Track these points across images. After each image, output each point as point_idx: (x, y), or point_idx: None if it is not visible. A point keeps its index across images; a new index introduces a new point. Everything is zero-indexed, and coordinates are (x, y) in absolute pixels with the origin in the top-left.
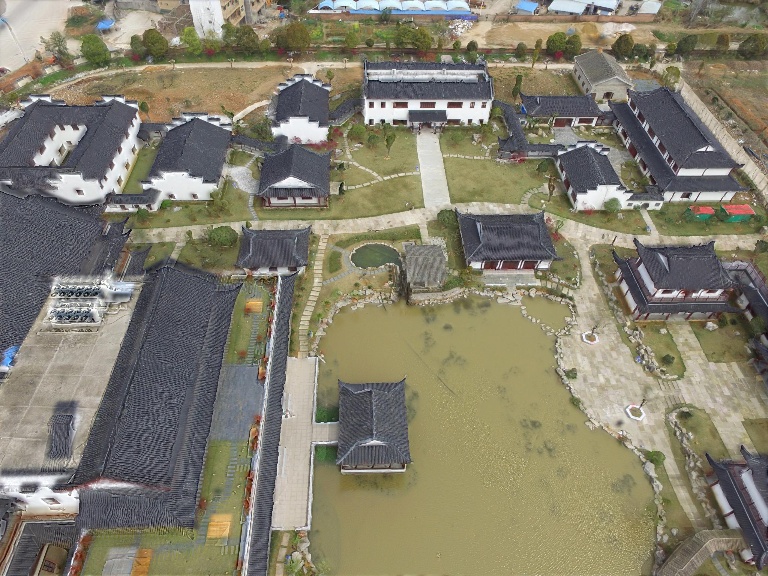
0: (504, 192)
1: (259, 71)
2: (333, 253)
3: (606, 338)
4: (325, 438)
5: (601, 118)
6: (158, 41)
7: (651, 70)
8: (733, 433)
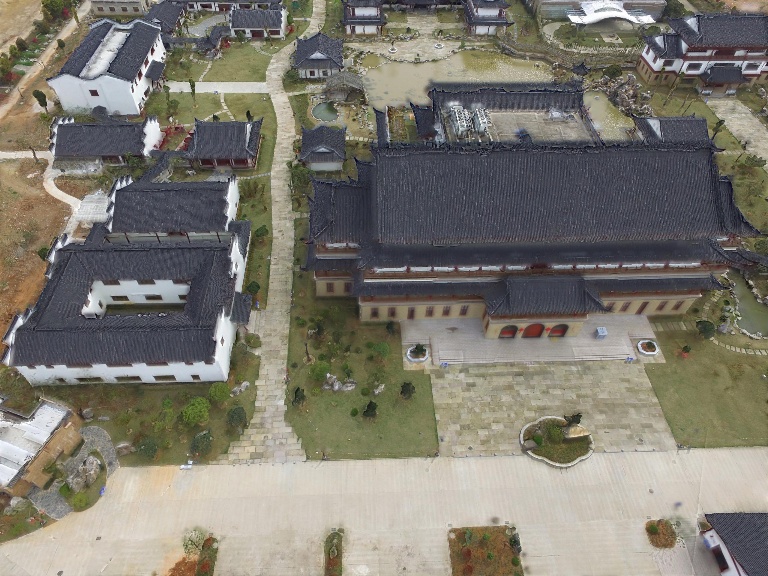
0: (257, 60)
1: None
2: None
3: None
4: None
5: None
6: None
7: None
8: None
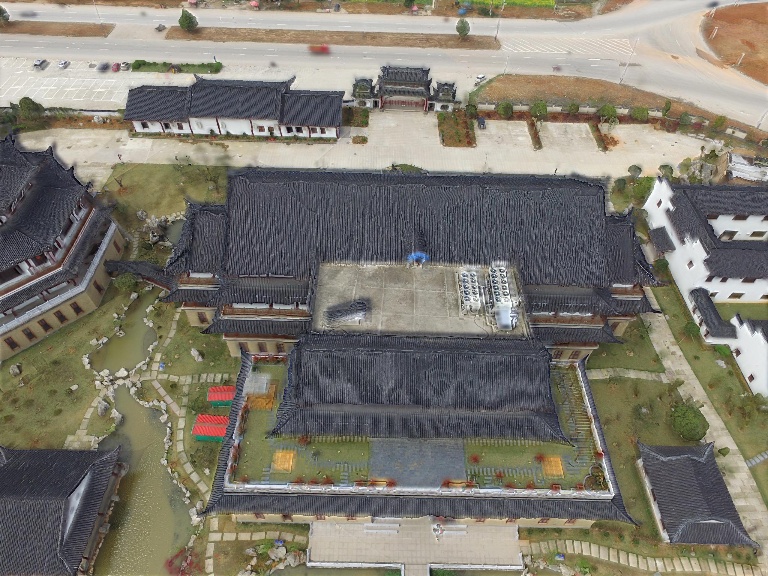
0: None
1: None
2: None
3: None
4: None
5: None
6: None
7: None
8: None
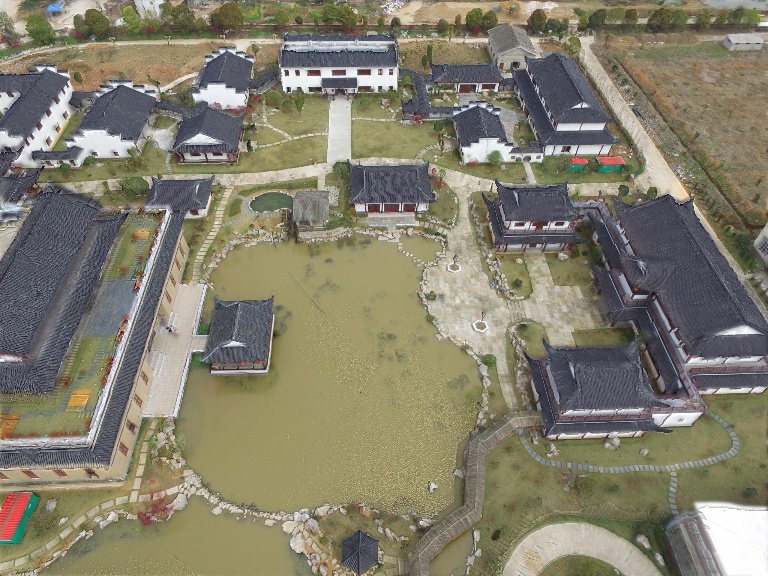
0: (402, 149)
1: (194, 47)
2: (235, 200)
3: (469, 268)
4: (202, 347)
5: (502, 84)
6: (98, 20)
7: (562, 42)
8: (562, 341)
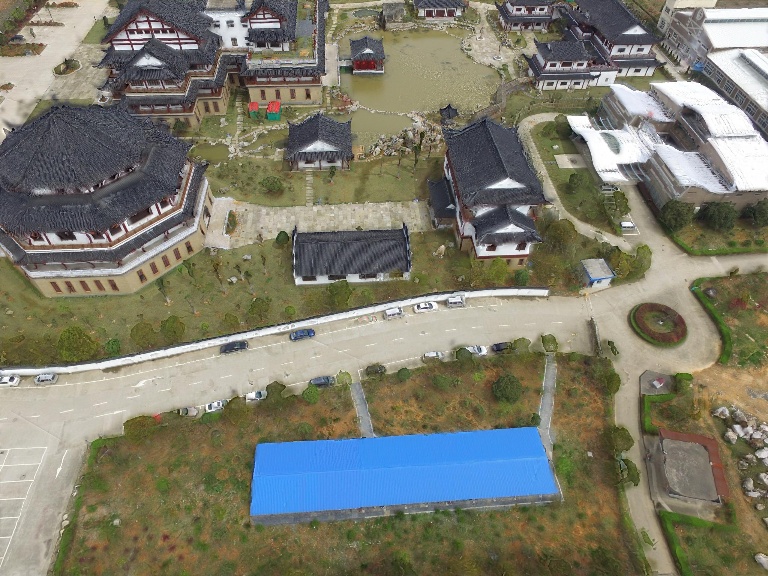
0: None
1: None
2: (342, 13)
3: (489, 39)
4: None
5: None
6: None
7: None
8: None
